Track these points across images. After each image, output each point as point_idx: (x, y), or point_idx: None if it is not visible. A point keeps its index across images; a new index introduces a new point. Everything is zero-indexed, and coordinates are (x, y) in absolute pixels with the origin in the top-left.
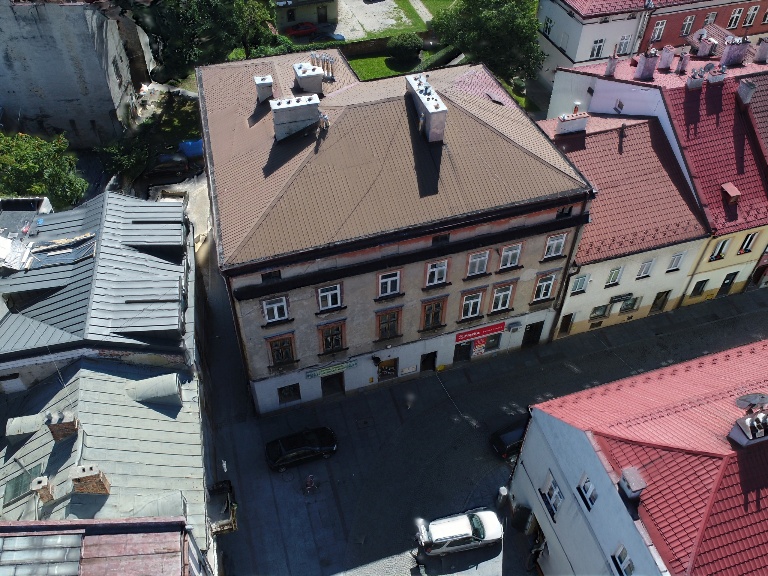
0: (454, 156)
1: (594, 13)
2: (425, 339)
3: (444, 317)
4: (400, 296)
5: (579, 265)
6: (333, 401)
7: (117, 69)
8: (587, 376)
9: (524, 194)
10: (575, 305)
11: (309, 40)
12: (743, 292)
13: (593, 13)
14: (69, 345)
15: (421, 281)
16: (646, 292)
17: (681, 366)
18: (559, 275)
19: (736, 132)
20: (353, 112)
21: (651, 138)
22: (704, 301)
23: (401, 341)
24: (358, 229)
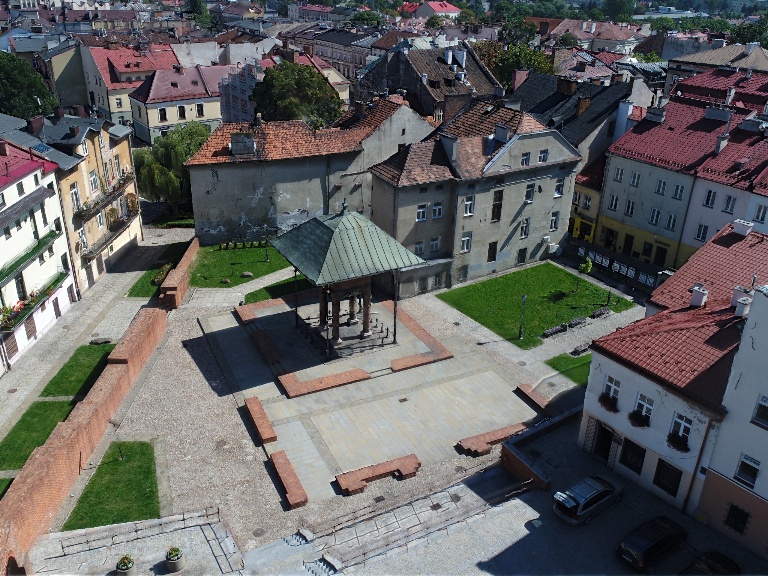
0: None
1: None
2: None
3: None
4: None
5: None
6: None
7: None
8: None
9: (757, 68)
10: None
11: None
12: None
13: None
14: (629, 65)
15: None
16: None
17: None
18: None
19: None
20: None
21: None
22: None
23: None
24: (706, 62)
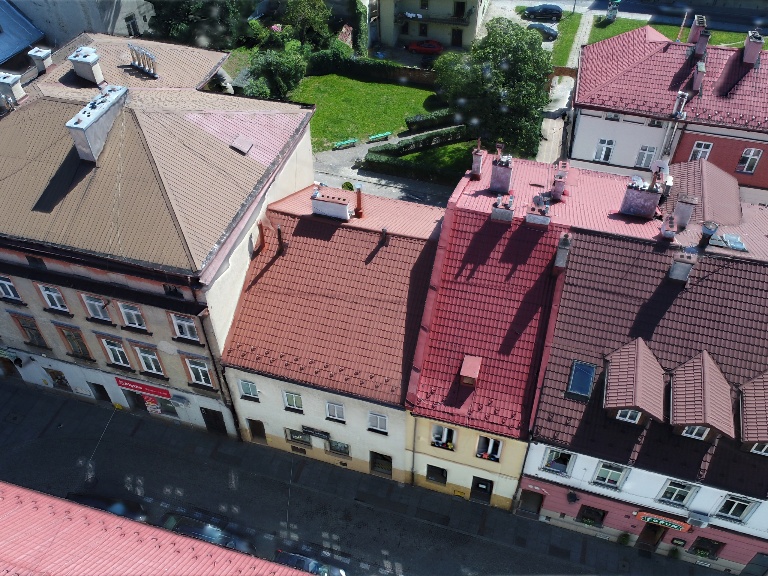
0: (95, 182)
1: (593, 103)
2: (80, 365)
3: (90, 351)
4: (22, 305)
5: (222, 364)
6: (15, 384)
7: (136, 26)
8: (236, 497)
9: (128, 250)
10: (256, 412)
11: (422, 58)
12: (511, 512)
13: (592, 103)
14: None
15: (40, 299)
16: (352, 442)
17: (121, 523)
18: (211, 365)
19: (529, 298)
20: (43, 104)
21: (417, 260)
22: (453, 495)
23: (56, 355)
24: None
